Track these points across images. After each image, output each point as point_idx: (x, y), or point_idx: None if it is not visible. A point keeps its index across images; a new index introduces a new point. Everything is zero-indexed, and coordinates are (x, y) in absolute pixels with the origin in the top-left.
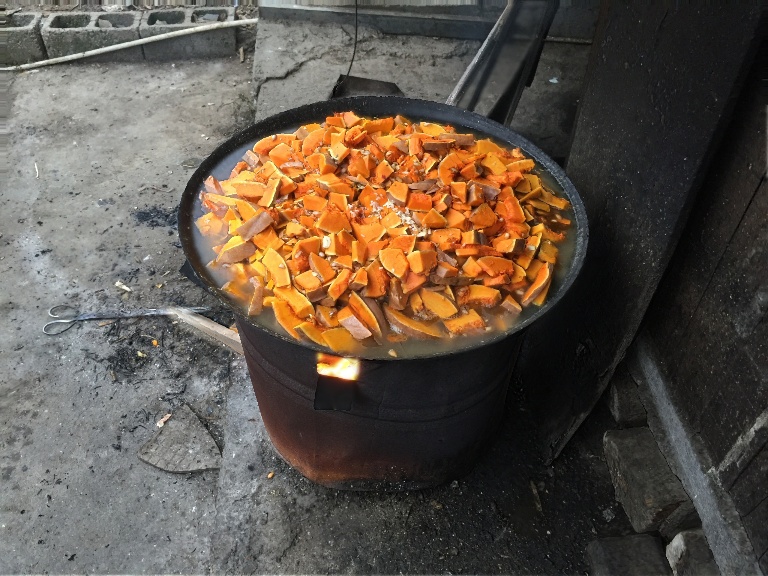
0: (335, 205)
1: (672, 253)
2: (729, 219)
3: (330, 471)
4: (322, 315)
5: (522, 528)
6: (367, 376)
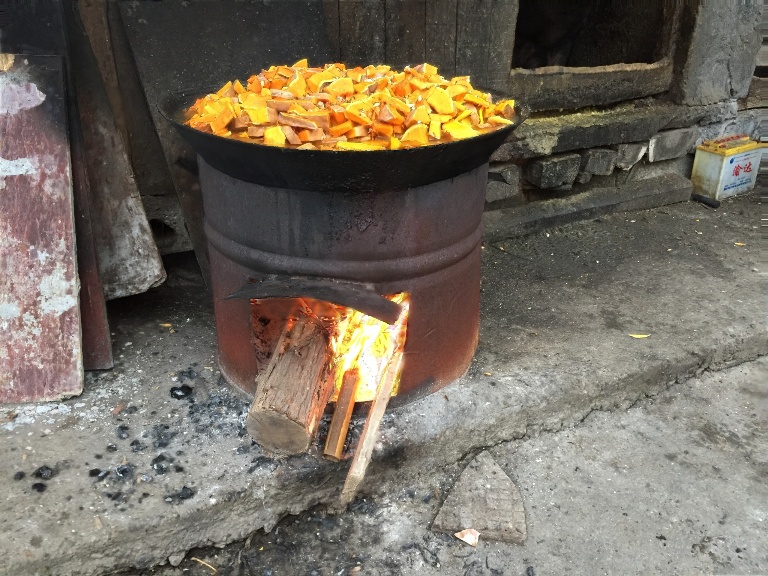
0: None
1: None
2: (331, 26)
3: None
4: None
5: None
6: None
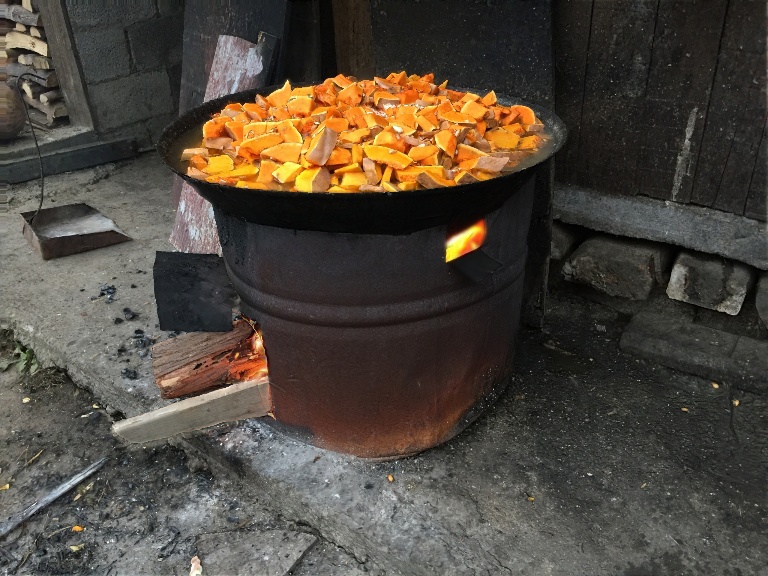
0: None
1: (555, 81)
2: (579, 35)
3: (449, 414)
4: None
5: (577, 369)
6: (492, 231)
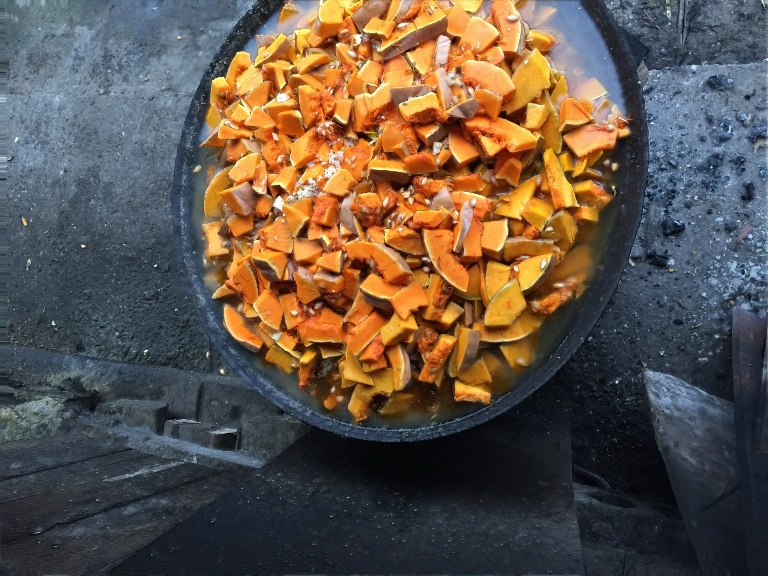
0: (334, 106)
1: None
2: None
3: None
4: (234, 103)
5: None
6: None
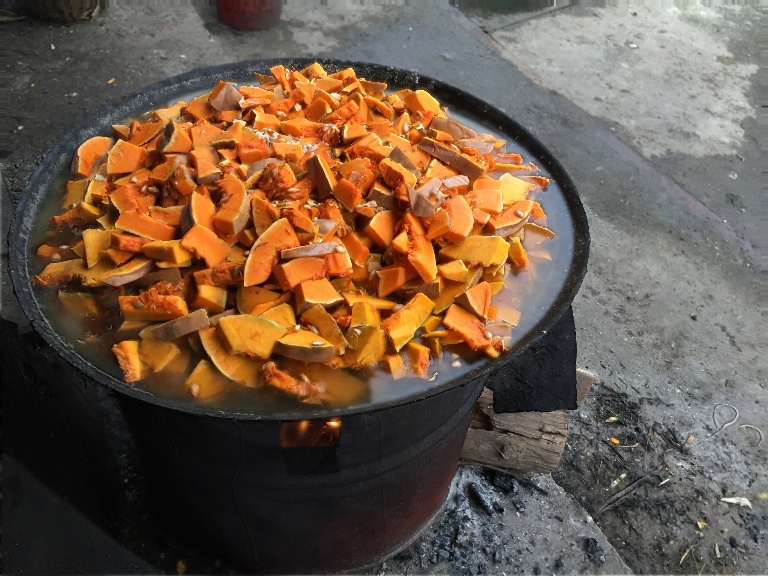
0: None
1: None
2: None
3: None
4: None
5: None
6: None
